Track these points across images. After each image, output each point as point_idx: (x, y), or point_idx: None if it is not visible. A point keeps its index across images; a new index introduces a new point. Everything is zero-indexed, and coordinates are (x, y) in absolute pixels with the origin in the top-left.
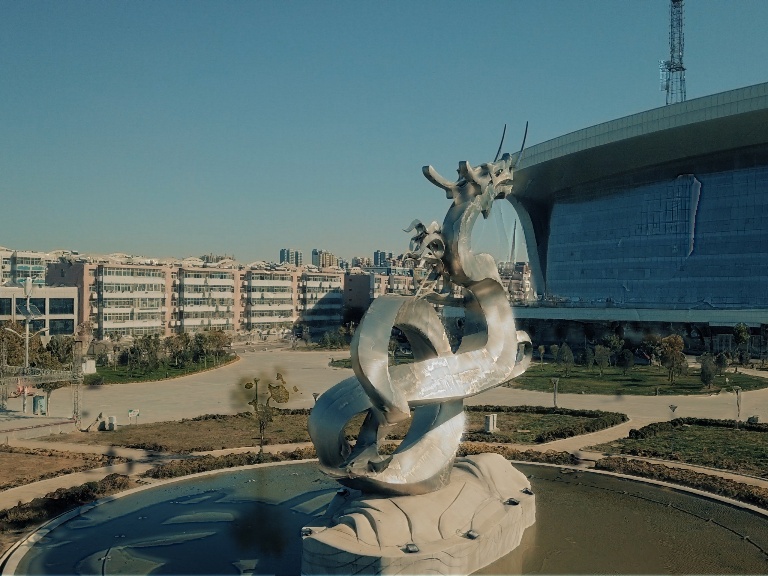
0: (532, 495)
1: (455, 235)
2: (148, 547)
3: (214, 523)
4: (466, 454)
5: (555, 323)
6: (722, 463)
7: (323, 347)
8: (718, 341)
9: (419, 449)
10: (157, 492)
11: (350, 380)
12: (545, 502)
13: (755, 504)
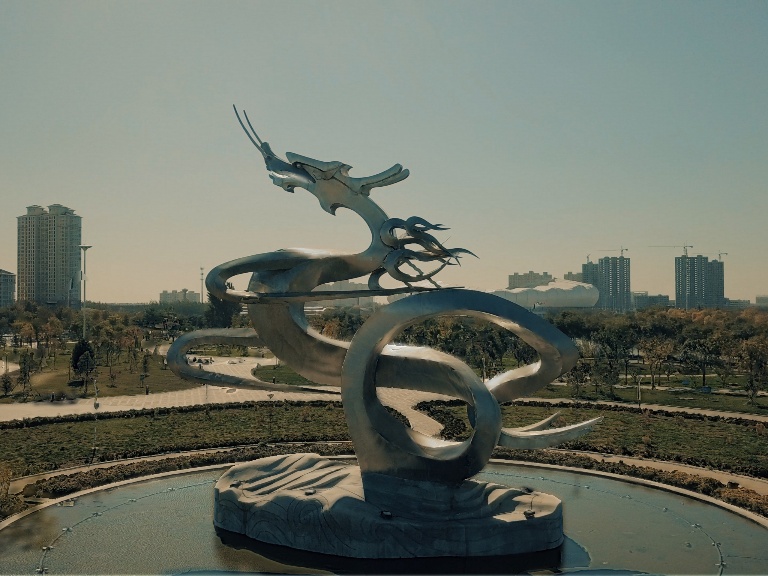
0: None
1: None
2: None
3: None
4: None
5: None
6: (45, 465)
7: None
8: None
9: None
10: None
11: (462, 373)
12: None
13: (215, 464)
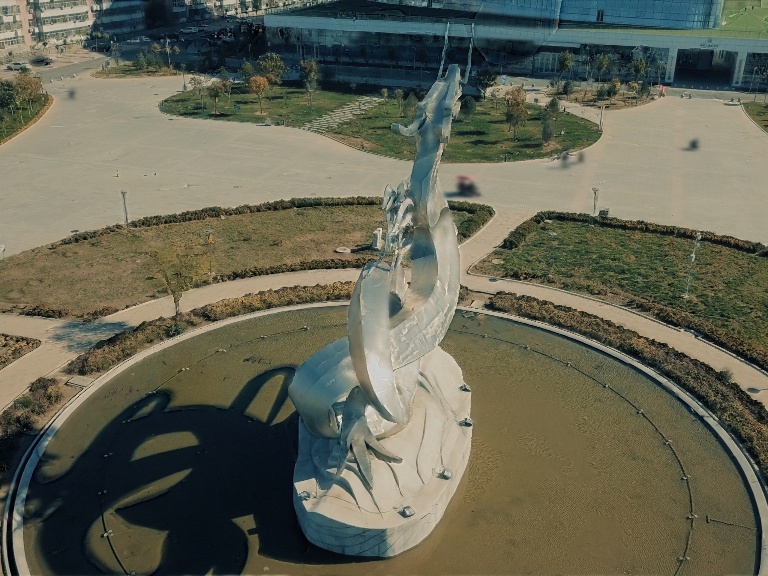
0: (470, 392)
1: (424, 194)
2: (138, 504)
3: (182, 452)
4: None
5: (383, 37)
6: (593, 288)
7: (138, 70)
8: (540, 59)
9: None
10: (97, 401)
11: (329, 350)
12: (466, 372)
13: (636, 357)
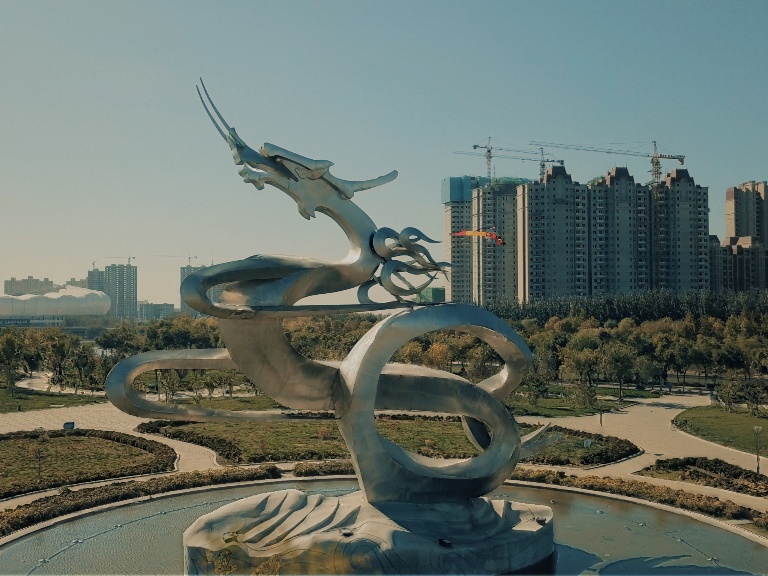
0: None
1: None
2: None
3: None
4: None
5: None
6: None
7: None
8: None
9: None
10: None
11: None
12: (154, 572)
13: None
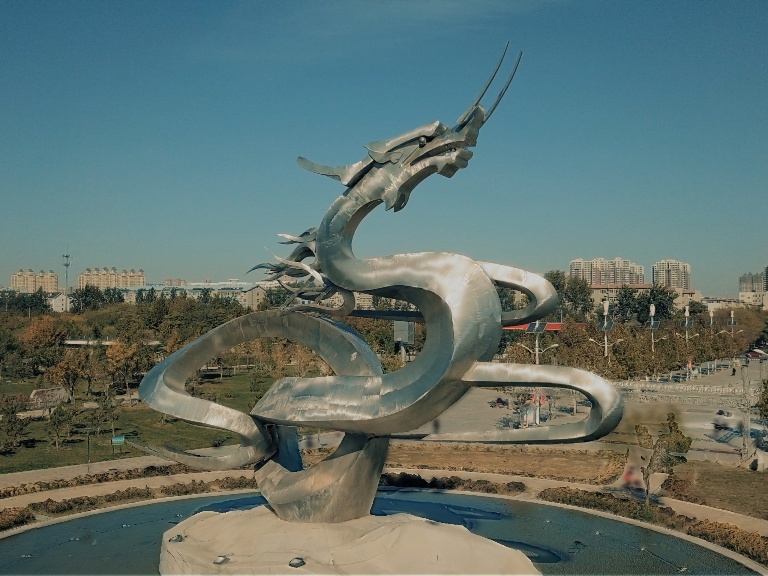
0: None
1: None
2: None
3: None
4: None
5: None
6: None
7: None
8: None
9: (303, 474)
10: (487, 501)
11: None
12: None
13: None
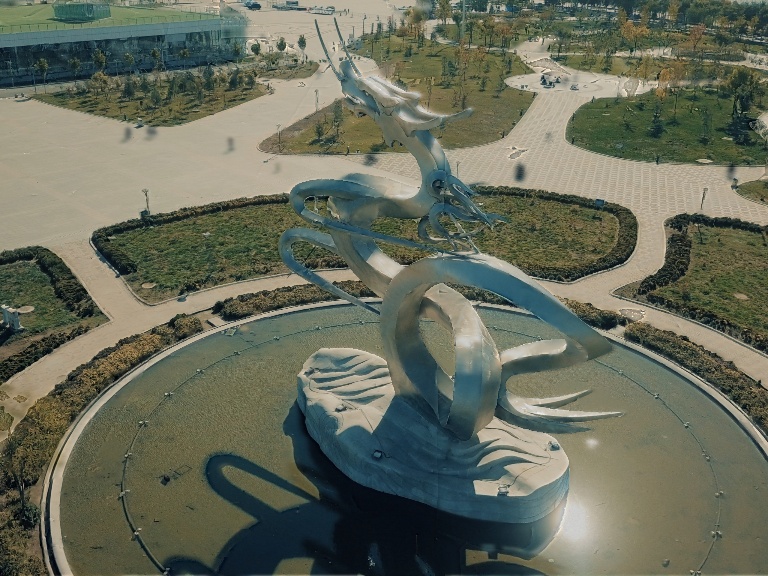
0: None
1: None
2: None
3: (319, 575)
4: (133, 364)
5: None
6: (259, 269)
7: None
8: None
9: None
10: None
11: (462, 351)
12: None
13: None
